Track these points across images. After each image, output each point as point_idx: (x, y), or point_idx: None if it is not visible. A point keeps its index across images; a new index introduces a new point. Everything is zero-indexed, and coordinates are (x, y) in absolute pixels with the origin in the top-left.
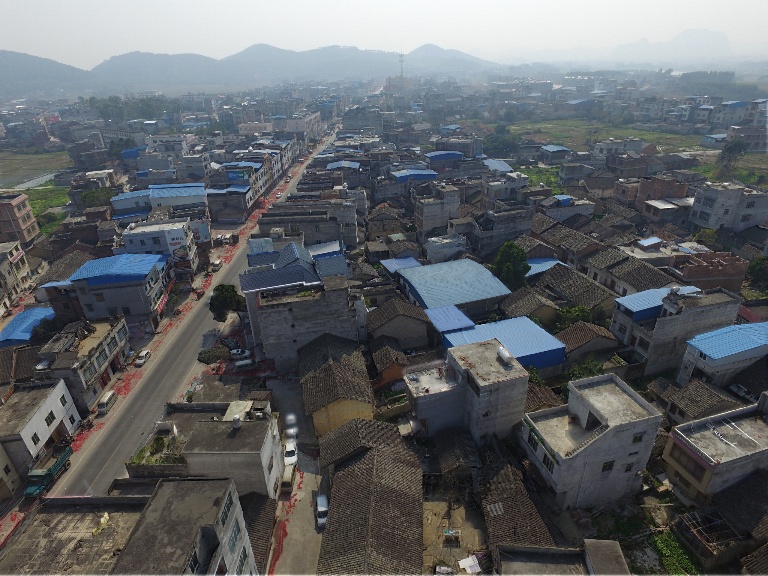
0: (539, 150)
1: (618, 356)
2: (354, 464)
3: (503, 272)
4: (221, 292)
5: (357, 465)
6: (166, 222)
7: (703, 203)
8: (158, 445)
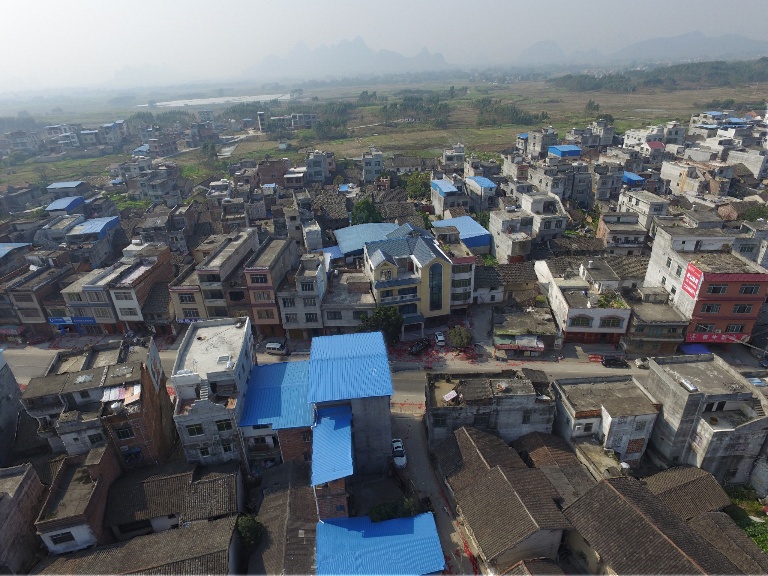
0: (46, 192)
1: (467, 213)
2: (572, 265)
3: (379, 217)
4: (388, 312)
5: (573, 264)
6: (184, 347)
7: (313, 166)
8: (606, 306)
